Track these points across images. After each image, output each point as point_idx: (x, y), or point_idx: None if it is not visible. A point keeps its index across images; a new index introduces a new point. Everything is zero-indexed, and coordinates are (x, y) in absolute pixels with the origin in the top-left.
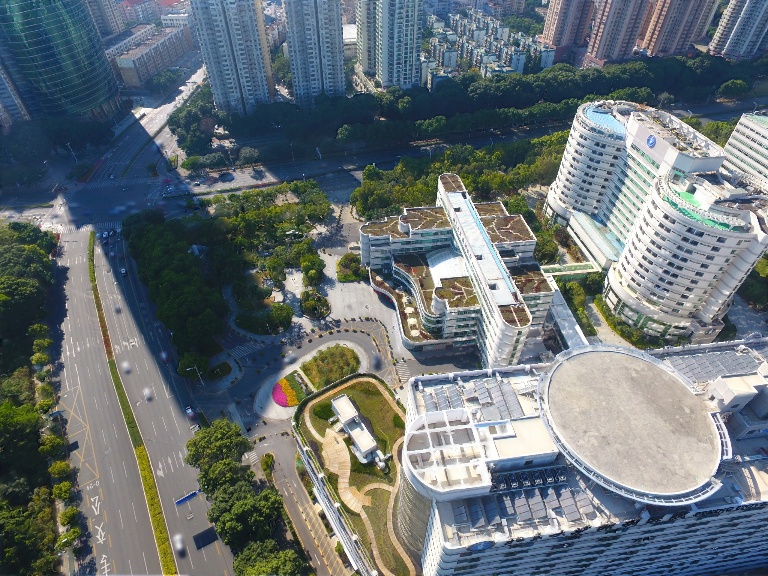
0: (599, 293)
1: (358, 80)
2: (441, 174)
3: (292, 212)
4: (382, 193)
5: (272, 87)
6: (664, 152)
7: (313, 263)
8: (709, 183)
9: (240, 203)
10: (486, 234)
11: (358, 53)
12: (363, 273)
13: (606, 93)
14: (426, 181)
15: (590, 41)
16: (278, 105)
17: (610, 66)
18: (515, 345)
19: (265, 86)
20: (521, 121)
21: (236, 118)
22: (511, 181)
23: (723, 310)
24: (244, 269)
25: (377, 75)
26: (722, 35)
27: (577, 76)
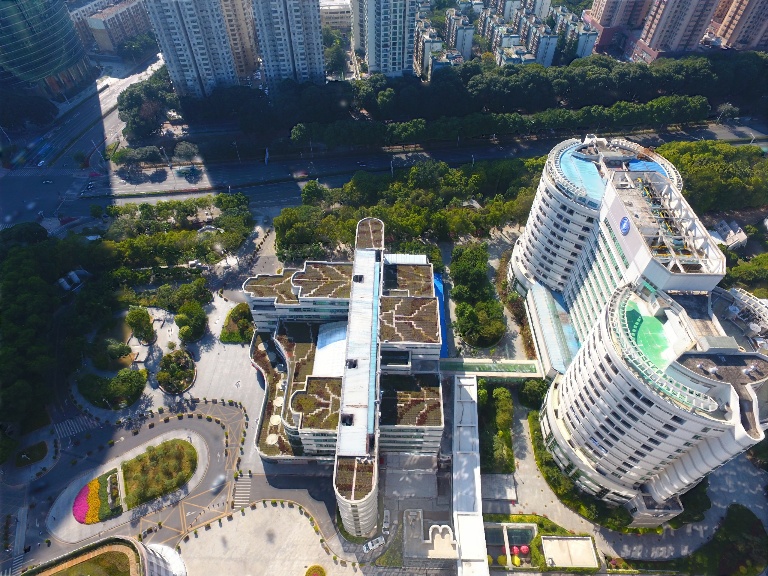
0: (538, 406)
1: (352, 58)
2: (396, 200)
3: (190, 242)
4: (303, 227)
5: (251, 61)
6: (636, 249)
7: (192, 315)
8: (686, 316)
9: (136, 223)
10: (377, 325)
11: (351, 26)
12: (248, 335)
13: (650, 97)
14: (366, 212)
15: (645, 24)
16: (234, 90)
17: (663, 61)
18: (354, 513)
19: (228, 64)
20: (524, 131)
21: (186, 103)
22: (477, 220)
23: None
24: (120, 309)
25: (366, 56)
26: None
27: (613, 73)
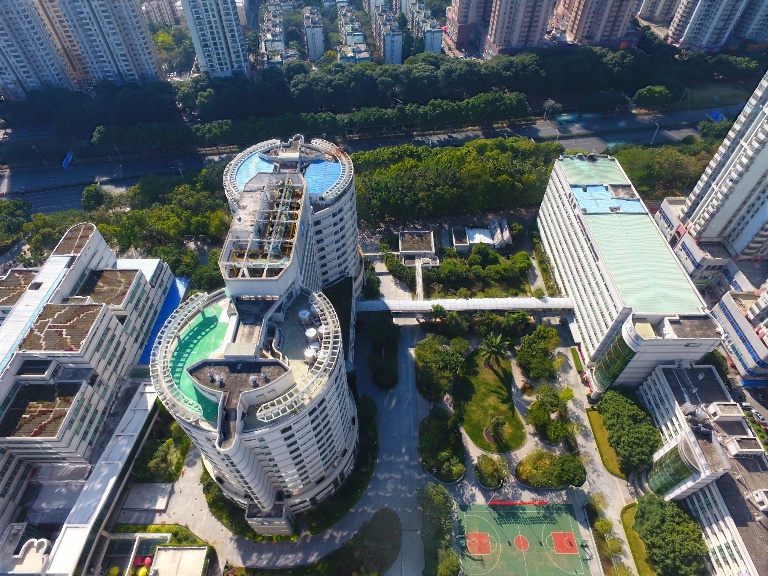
0: None
1: None
2: None
3: None
4: (50, 232)
5: None
6: None
7: None
8: (235, 322)
9: None
10: (24, 334)
11: None
12: None
13: None
14: None
15: (490, 20)
16: (48, 93)
17: (498, 57)
18: None
19: (51, 66)
20: (337, 130)
21: None
22: None
23: (304, 489)
24: None
25: None
26: (682, 17)
27: (439, 71)
